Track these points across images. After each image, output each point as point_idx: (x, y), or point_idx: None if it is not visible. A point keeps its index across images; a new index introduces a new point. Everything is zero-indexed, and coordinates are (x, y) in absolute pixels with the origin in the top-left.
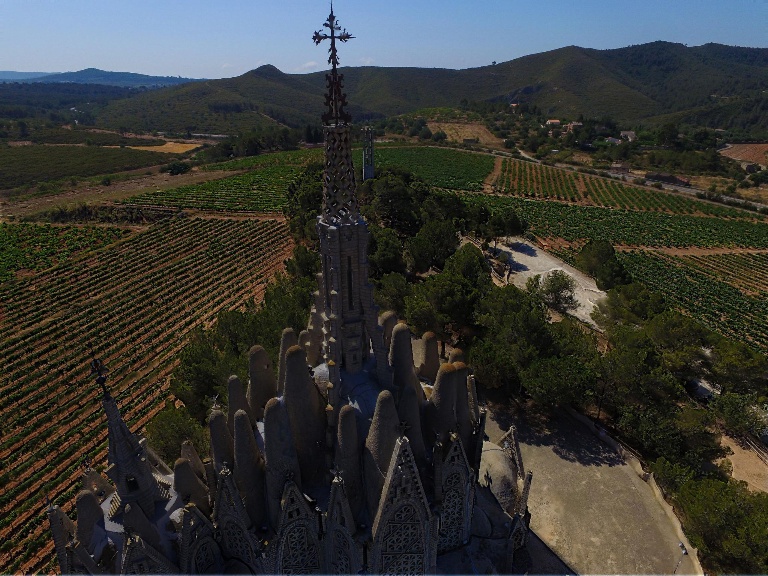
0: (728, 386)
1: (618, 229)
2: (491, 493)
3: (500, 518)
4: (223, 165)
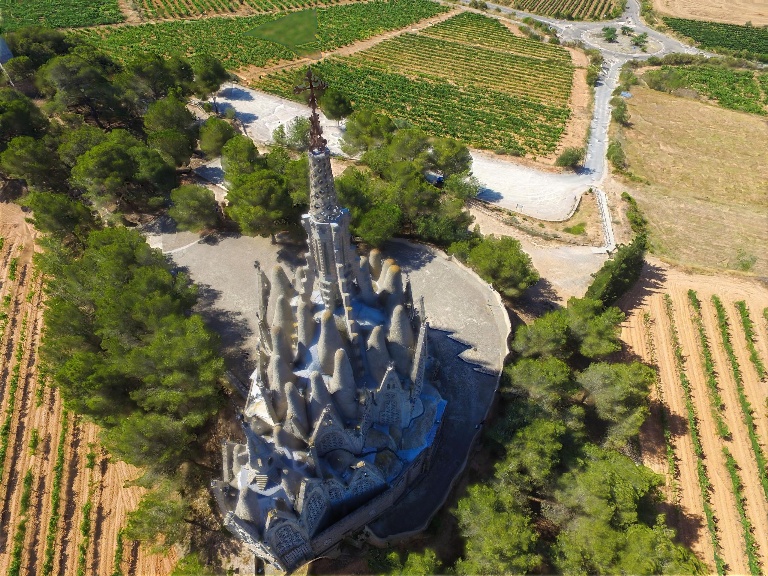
0: (448, 171)
1: None
2: None
3: None
4: None
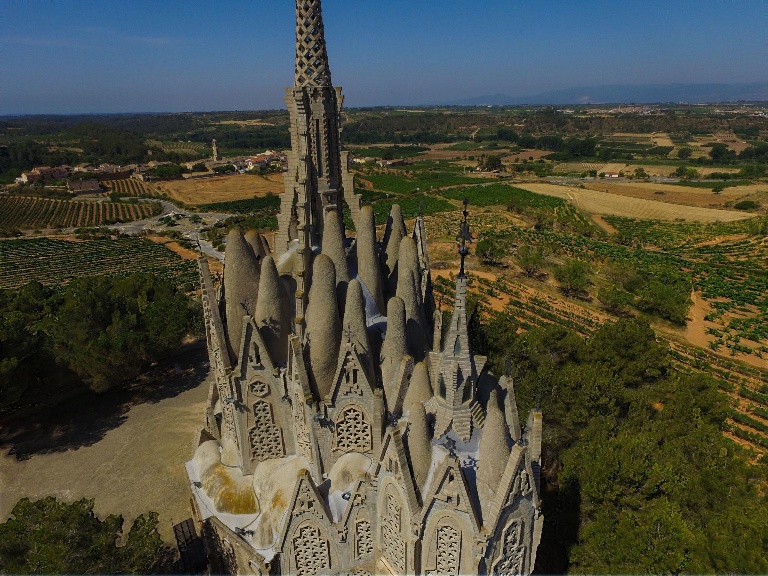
0: None
1: None
2: None
3: None
4: None
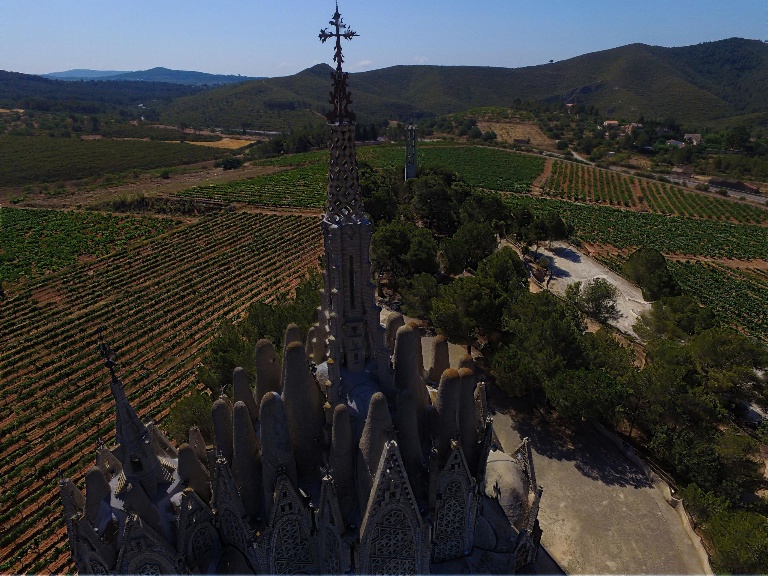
0: None
1: (674, 237)
2: (499, 505)
3: (506, 531)
4: (273, 161)
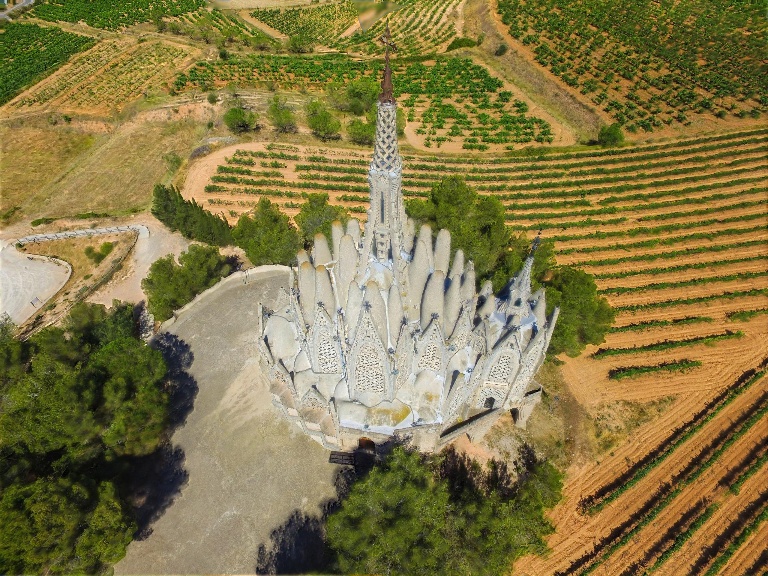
0: None
1: None
2: None
3: None
4: None
